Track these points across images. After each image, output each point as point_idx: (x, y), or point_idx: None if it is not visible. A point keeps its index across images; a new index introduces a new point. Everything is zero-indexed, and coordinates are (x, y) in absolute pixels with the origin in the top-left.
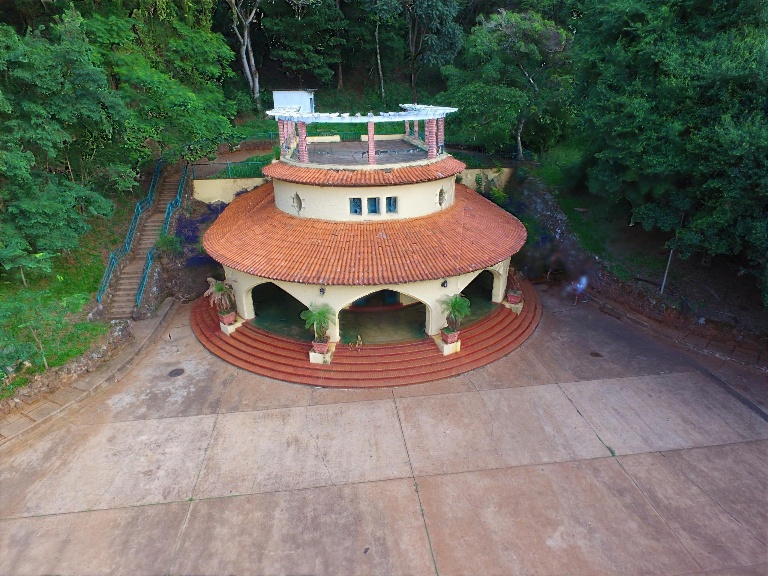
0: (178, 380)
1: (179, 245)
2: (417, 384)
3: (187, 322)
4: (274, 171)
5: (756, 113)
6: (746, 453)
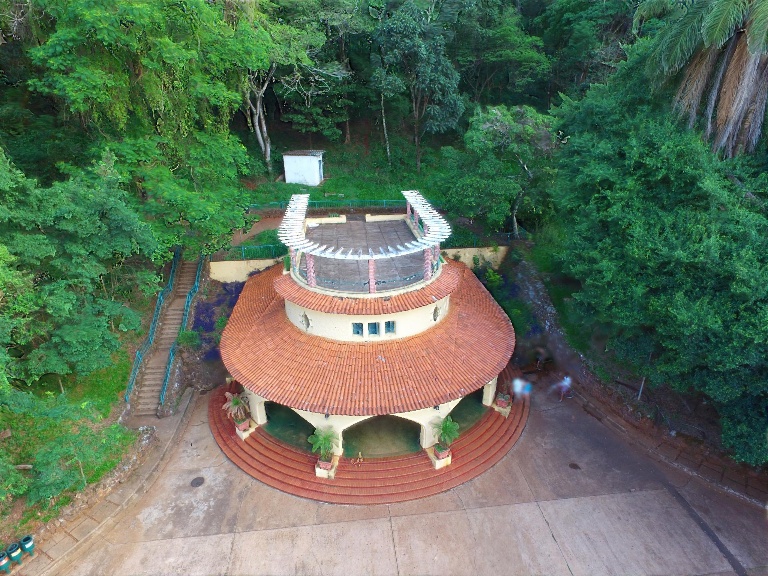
0: (199, 491)
1: (198, 340)
2: (411, 500)
3: (205, 419)
4: (285, 290)
5: (706, 292)
6: None
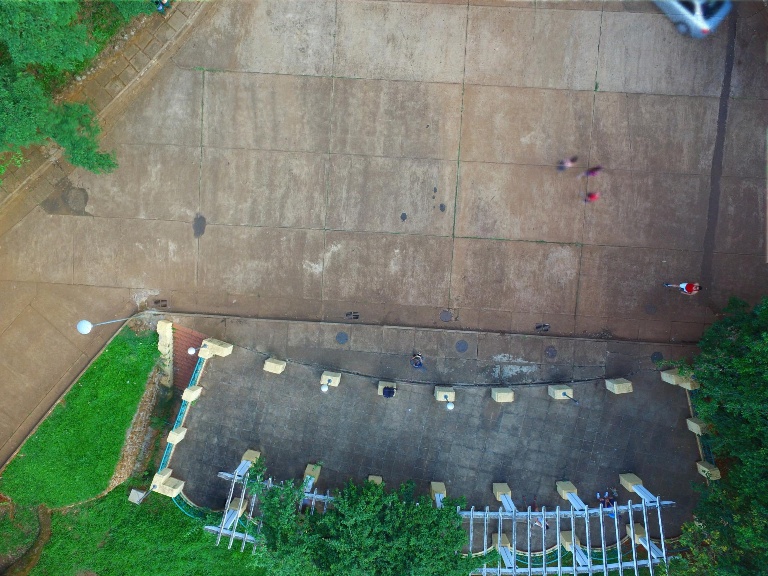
0: None
1: None
2: None
3: None
4: None
5: None
6: (681, 105)
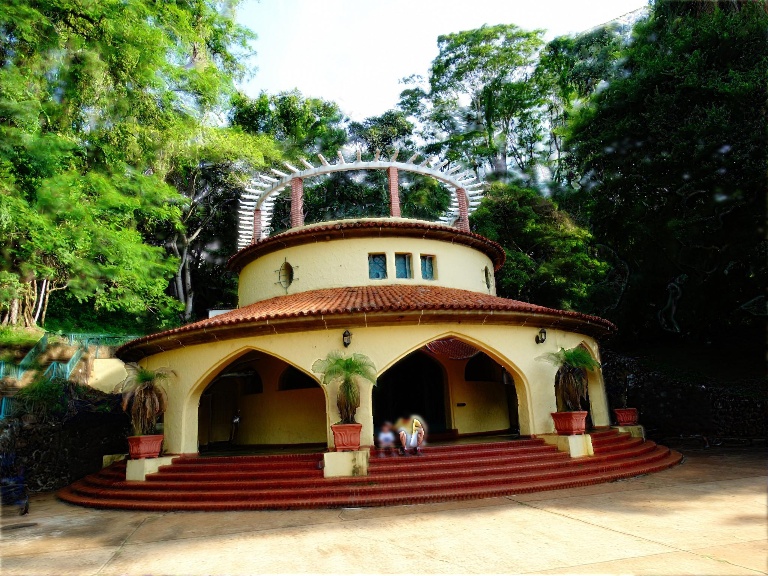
0: (21, 529)
1: (61, 395)
2: (549, 490)
3: (49, 498)
4: None
5: None
6: None
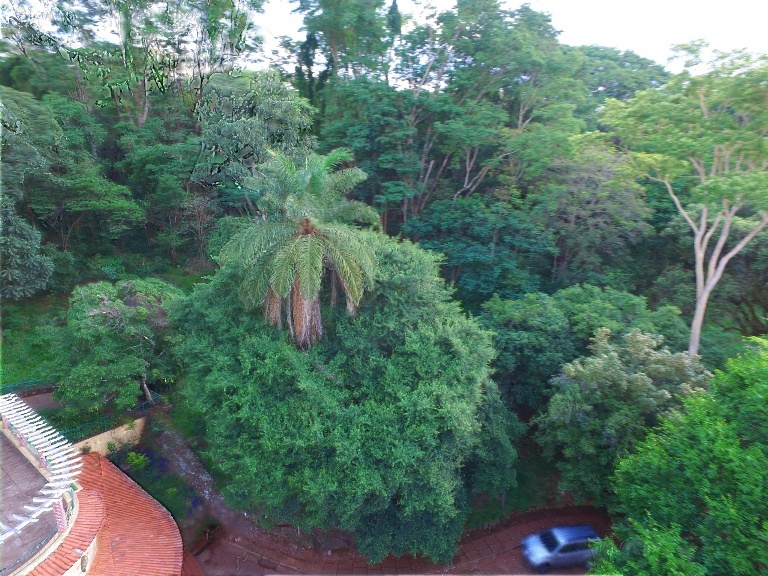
0: None
1: None
2: None
3: None
4: None
5: (322, 460)
6: None
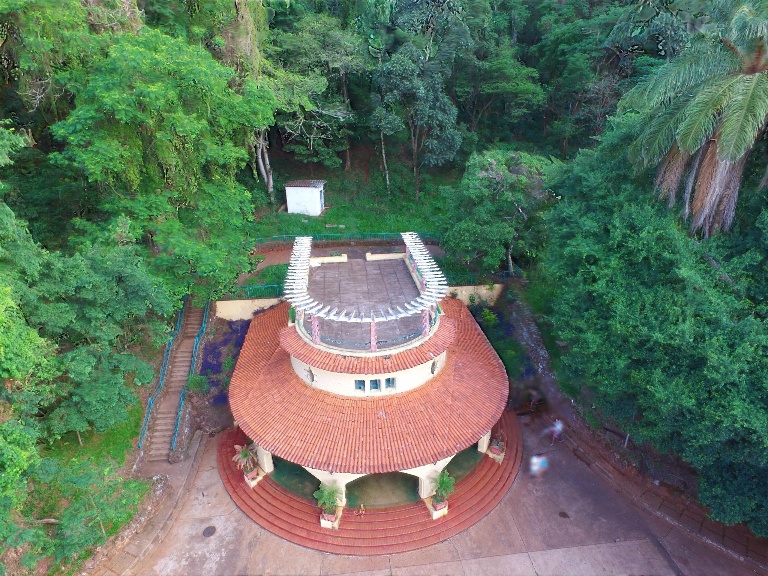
0: (211, 541)
1: None
2: (410, 551)
3: (215, 464)
4: (291, 345)
5: (682, 369)
6: None
